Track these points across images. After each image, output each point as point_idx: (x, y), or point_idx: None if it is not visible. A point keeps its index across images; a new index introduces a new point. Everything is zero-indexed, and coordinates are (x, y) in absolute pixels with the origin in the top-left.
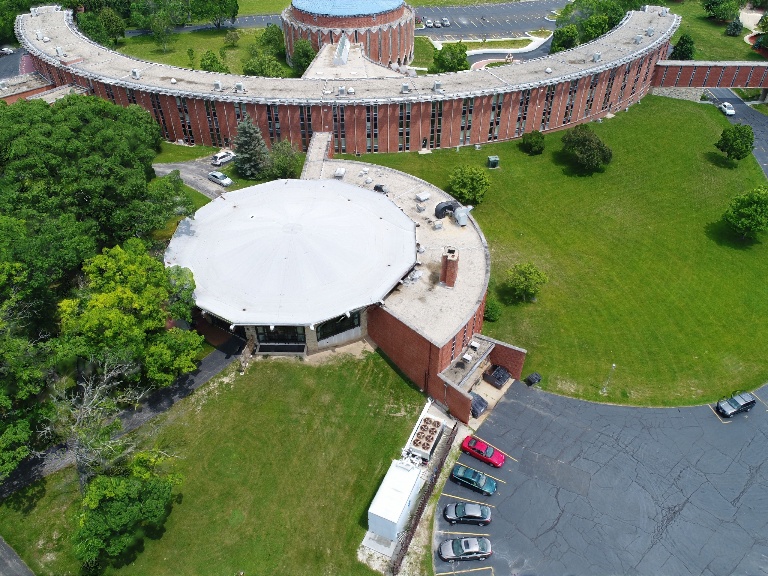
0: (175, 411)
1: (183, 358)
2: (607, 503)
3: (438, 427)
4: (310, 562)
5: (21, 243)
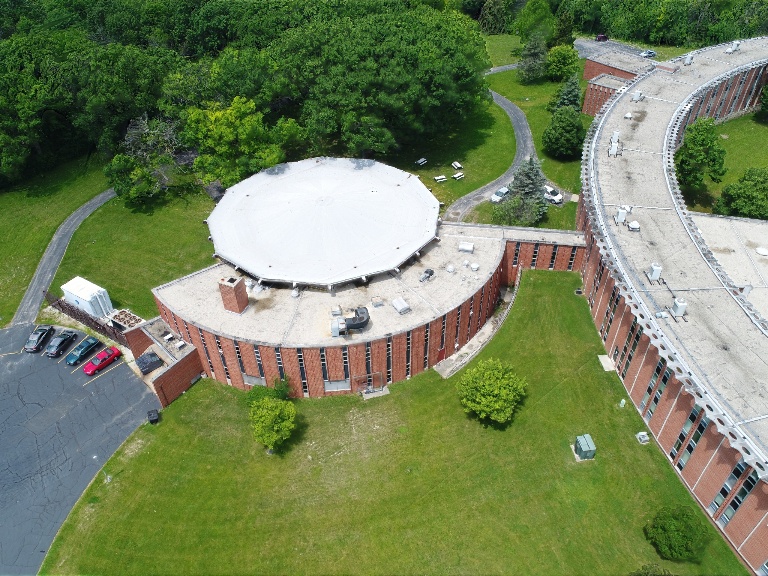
0: (211, 204)
1: (209, 175)
2: (8, 438)
3: (128, 326)
4: (84, 270)
5: (234, 65)
